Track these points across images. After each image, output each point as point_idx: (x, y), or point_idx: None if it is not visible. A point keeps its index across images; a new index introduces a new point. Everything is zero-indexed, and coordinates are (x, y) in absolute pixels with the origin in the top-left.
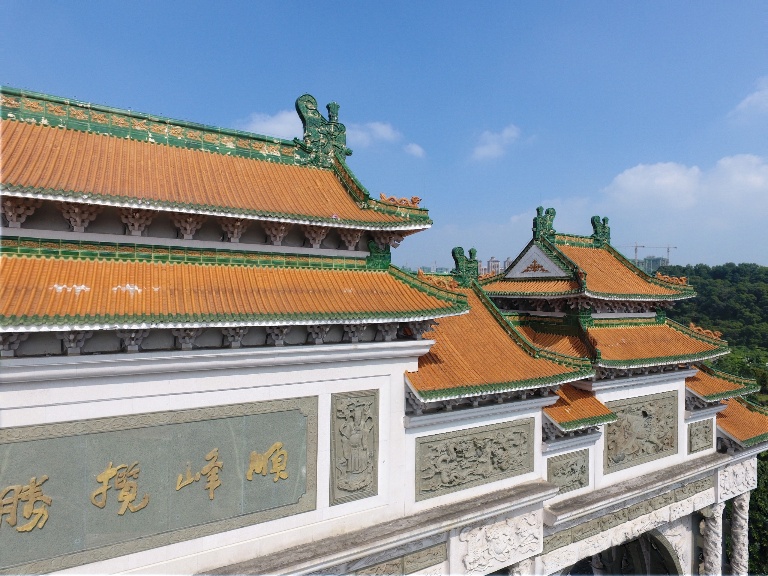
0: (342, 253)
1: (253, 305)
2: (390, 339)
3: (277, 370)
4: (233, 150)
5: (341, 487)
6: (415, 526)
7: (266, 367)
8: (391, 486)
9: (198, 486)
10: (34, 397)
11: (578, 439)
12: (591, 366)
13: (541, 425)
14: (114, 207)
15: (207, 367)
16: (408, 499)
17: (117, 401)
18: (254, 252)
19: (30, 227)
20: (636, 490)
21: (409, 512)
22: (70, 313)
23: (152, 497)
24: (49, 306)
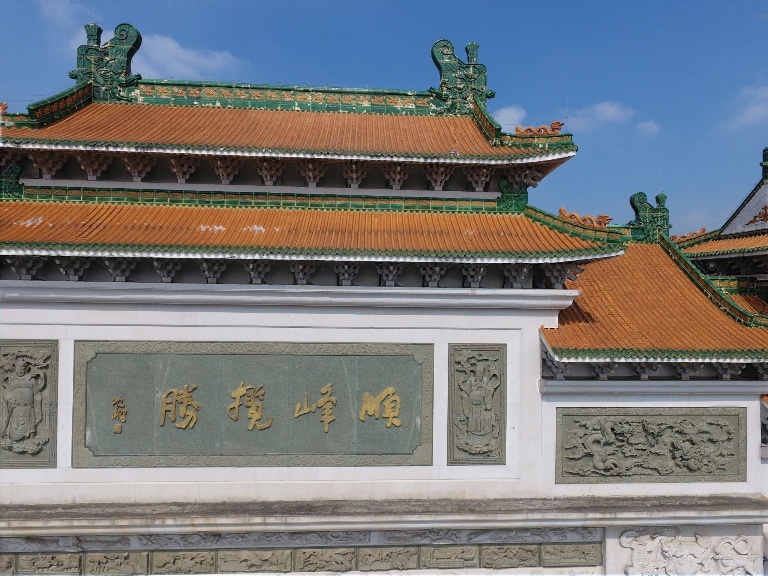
0: (468, 195)
1: (361, 243)
2: (519, 287)
3: (389, 312)
4: (369, 108)
5: (460, 447)
6: (551, 509)
7: (377, 308)
8: (523, 458)
9: (314, 417)
10: (186, 318)
11: None
12: None
13: (759, 420)
14: (251, 161)
15: (319, 303)
16: (546, 478)
17: (246, 328)
18: (373, 196)
19: (192, 182)
20: None
21: (547, 494)
22: (203, 245)
23: (275, 420)
24: (191, 240)
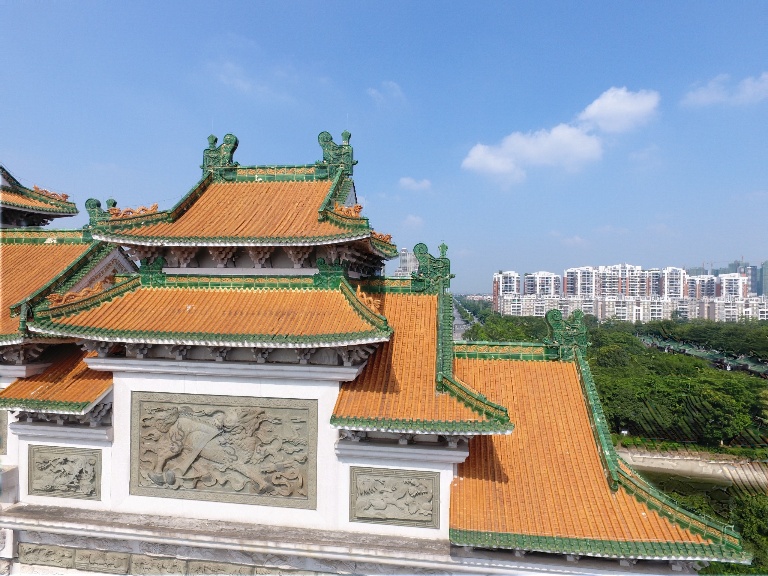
0: None
1: None
2: None
3: None
4: None
5: None
6: None
7: None
8: None
9: None
10: None
11: (59, 429)
12: (19, 329)
13: None
14: None
15: None
16: None
17: None
18: None
19: None
20: (147, 530)
21: None
22: None
23: None
24: None
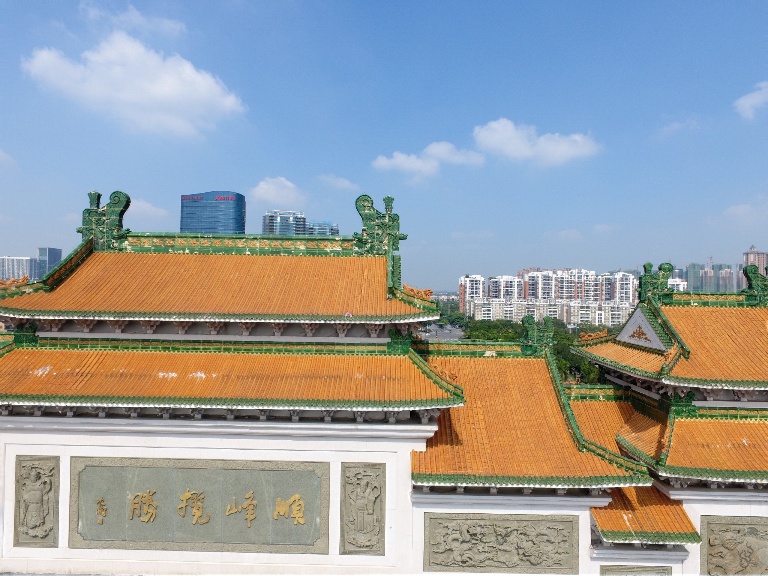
0: (365, 340)
1: (272, 390)
2: (394, 421)
3: (296, 439)
4: (304, 251)
5: (349, 541)
6: None
7: (286, 436)
8: (398, 551)
9: (240, 516)
10: (148, 441)
11: (645, 553)
12: (647, 473)
13: (589, 526)
14: None
15: (243, 433)
16: (416, 567)
17: (191, 449)
18: (291, 343)
19: (158, 332)
20: None
21: None
22: (157, 395)
23: (212, 517)
24: (149, 389)
